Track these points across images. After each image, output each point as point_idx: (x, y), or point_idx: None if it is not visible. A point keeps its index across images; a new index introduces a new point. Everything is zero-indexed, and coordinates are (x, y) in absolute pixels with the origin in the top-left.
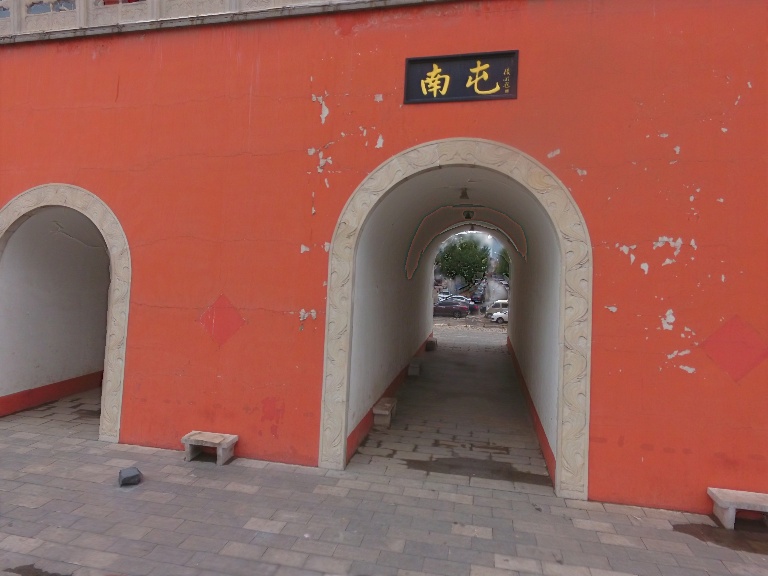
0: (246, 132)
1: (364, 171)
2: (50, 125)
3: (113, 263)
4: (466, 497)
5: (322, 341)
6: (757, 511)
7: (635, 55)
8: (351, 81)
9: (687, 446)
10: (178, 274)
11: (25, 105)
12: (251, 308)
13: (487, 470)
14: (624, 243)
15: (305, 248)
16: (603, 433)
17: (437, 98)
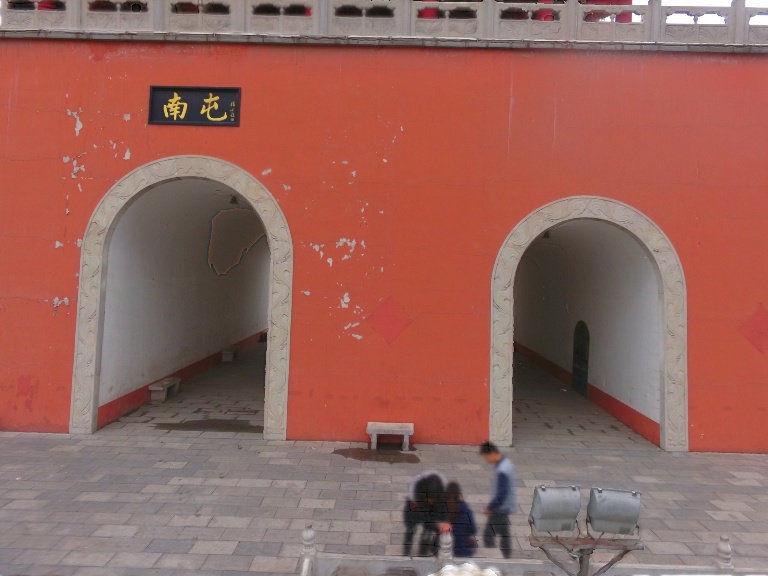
0: (4, 139)
1: (113, 179)
2: None
3: None
4: (187, 445)
5: (74, 324)
6: (390, 434)
7: (327, 100)
8: (103, 101)
9: (356, 393)
10: None
11: None
12: (8, 297)
13: (224, 426)
14: (316, 243)
15: (59, 244)
16: (298, 388)
17: (176, 121)
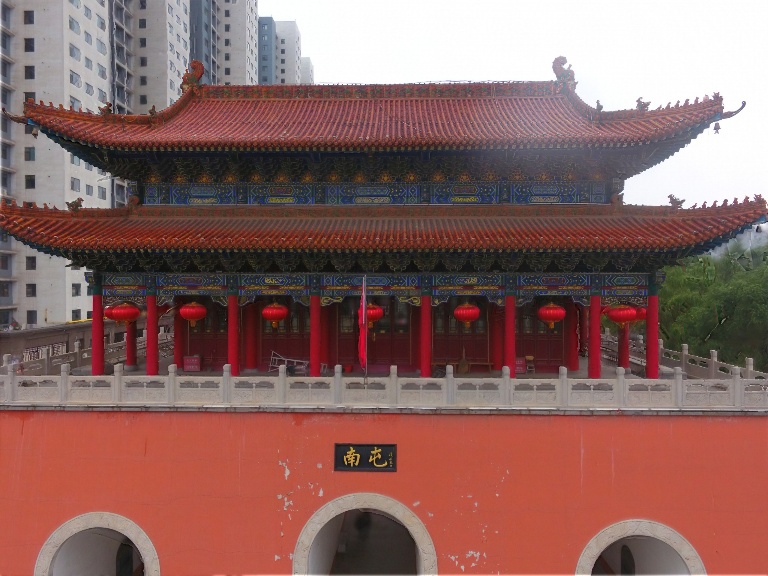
0: (237, 482)
1: (312, 510)
2: (94, 469)
3: (146, 568)
4: None
5: None
6: None
7: (455, 451)
8: (303, 454)
9: None
10: (194, 574)
11: (73, 454)
12: None
13: None
14: (452, 555)
15: (278, 557)
16: None
17: (353, 468)
